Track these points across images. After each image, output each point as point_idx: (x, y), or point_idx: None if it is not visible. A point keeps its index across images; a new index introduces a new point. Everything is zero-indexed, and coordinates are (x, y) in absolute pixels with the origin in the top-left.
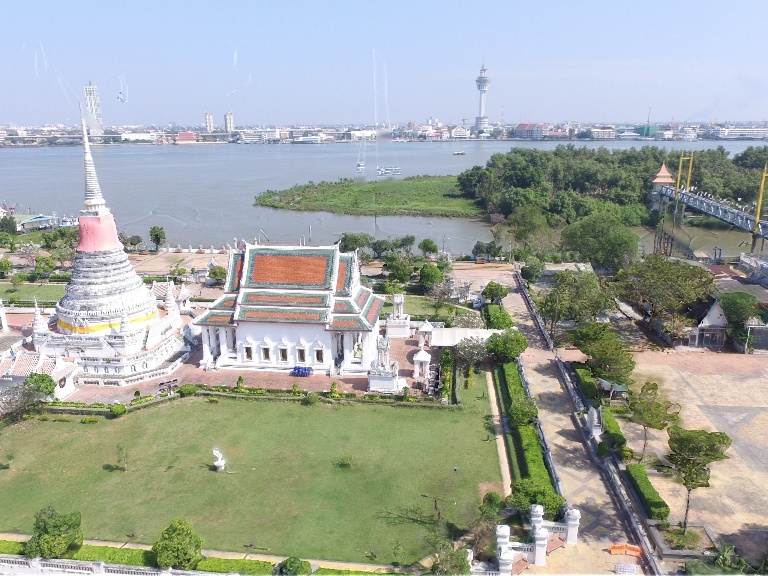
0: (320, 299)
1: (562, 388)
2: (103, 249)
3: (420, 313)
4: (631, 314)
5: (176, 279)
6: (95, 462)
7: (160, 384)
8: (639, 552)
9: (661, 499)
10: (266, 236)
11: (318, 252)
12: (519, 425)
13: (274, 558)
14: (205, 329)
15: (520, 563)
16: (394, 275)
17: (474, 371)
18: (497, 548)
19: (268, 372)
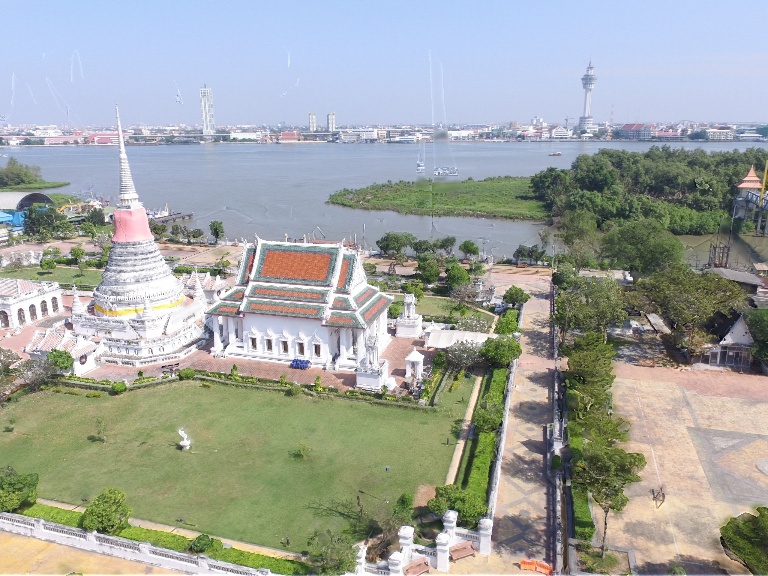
0: (320, 295)
1: (548, 398)
2: (133, 240)
3: (437, 314)
4: (660, 327)
5: (221, 271)
6: (83, 432)
7: (162, 367)
8: (549, 570)
9: (590, 519)
10: (322, 233)
11: (323, 249)
12: (481, 431)
13: (197, 534)
14: (216, 318)
15: (420, 566)
16: (421, 275)
17: (464, 375)
18: (399, 548)
19: (270, 363)
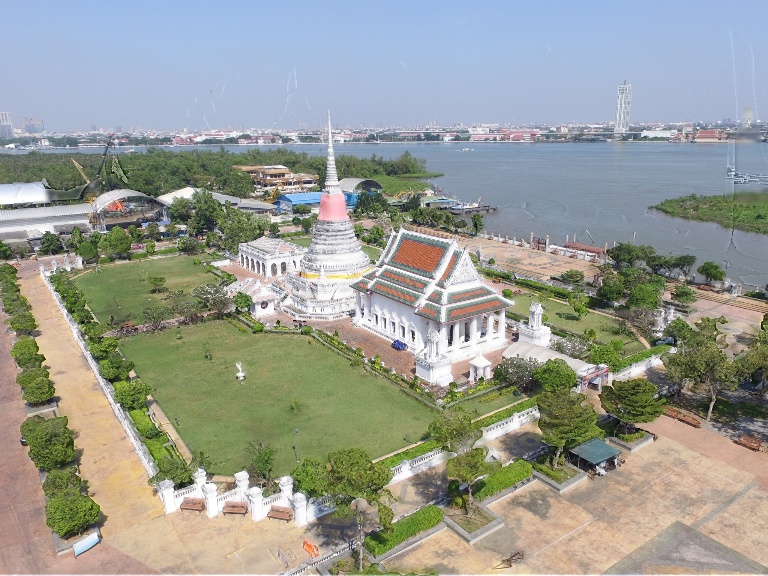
0: (423, 285)
1: None
2: (328, 219)
3: None
4: None
5: None
6: None
7: (294, 320)
8: None
9: (390, 537)
10: (591, 237)
11: (441, 243)
12: None
13: (173, 431)
14: (357, 292)
15: None
16: None
17: (513, 392)
18: (236, 487)
19: (383, 339)
